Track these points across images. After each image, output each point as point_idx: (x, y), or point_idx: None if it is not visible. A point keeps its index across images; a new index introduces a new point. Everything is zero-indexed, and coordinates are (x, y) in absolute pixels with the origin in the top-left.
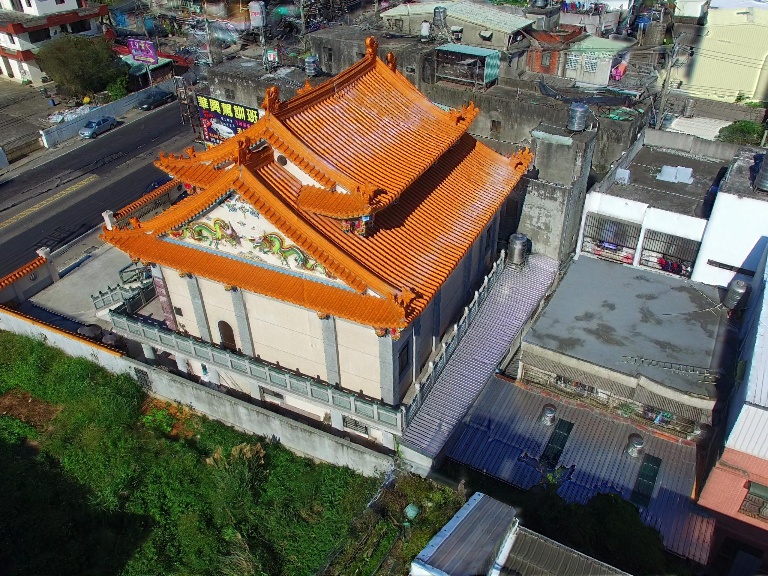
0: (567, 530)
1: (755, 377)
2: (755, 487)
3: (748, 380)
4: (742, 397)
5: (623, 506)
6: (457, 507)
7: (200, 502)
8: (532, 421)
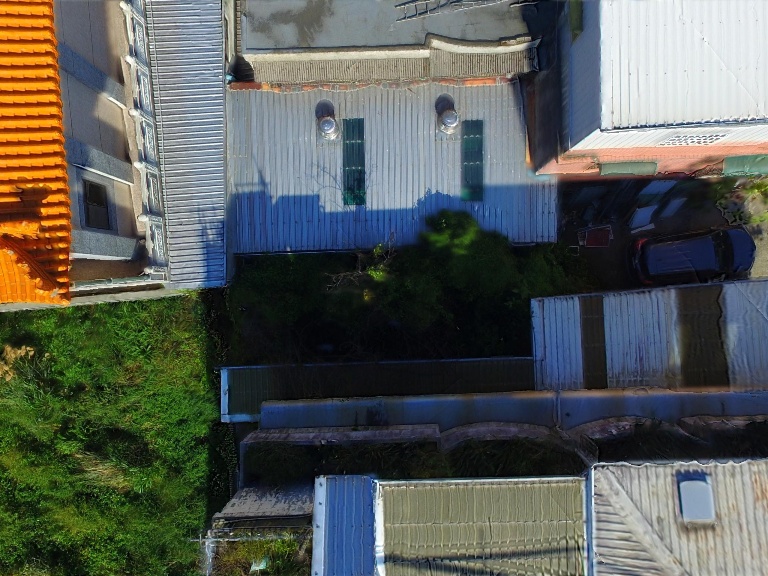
0: (413, 317)
1: (608, 67)
2: (606, 170)
3: (599, 78)
4: (588, 85)
5: (461, 244)
6: (308, 550)
7: (5, 431)
8: (311, 144)
